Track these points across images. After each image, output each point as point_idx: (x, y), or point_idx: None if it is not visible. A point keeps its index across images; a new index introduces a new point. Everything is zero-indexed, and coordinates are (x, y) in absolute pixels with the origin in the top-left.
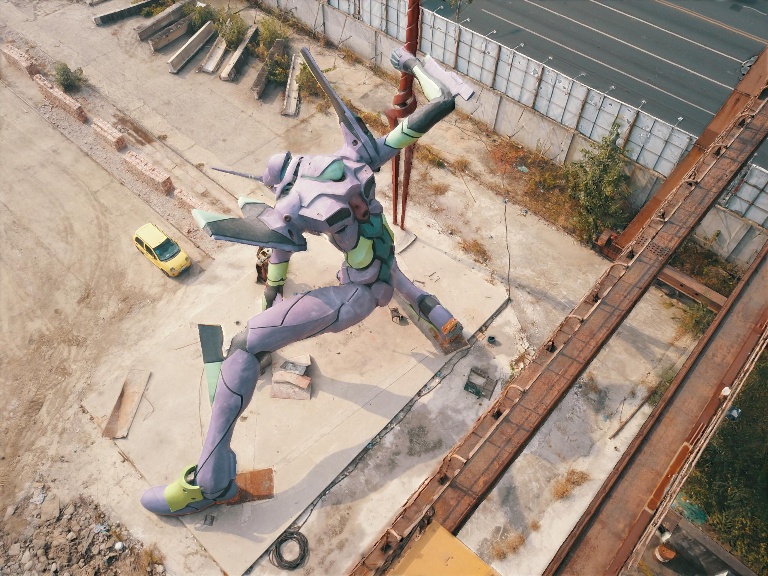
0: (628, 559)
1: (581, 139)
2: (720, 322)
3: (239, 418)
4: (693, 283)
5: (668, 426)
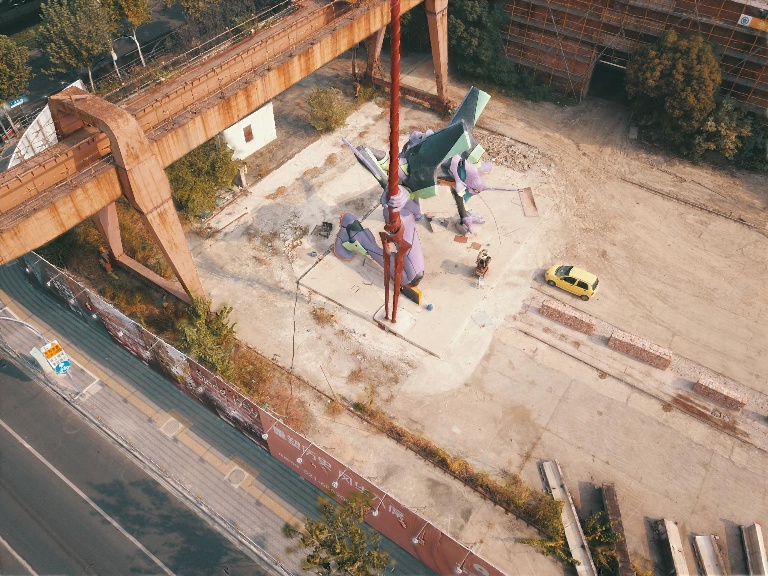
0: (299, 7)
1: None
2: None
3: None
4: (158, 280)
5: (275, 31)
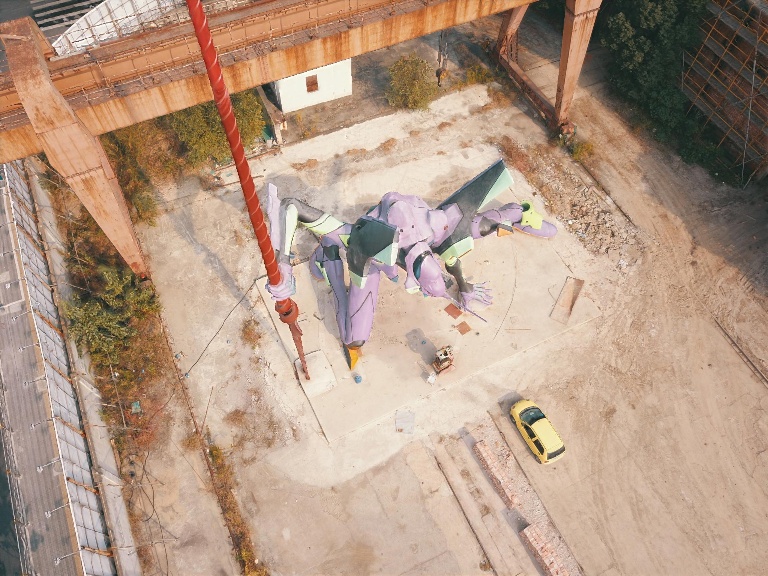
0: None
1: (76, 368)
2: (264, 13)
3: (490, 262)
4: None
5: None
